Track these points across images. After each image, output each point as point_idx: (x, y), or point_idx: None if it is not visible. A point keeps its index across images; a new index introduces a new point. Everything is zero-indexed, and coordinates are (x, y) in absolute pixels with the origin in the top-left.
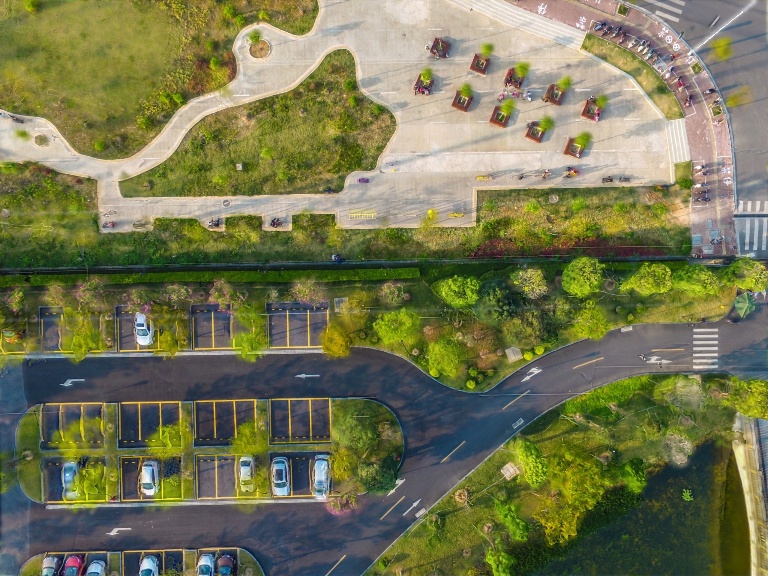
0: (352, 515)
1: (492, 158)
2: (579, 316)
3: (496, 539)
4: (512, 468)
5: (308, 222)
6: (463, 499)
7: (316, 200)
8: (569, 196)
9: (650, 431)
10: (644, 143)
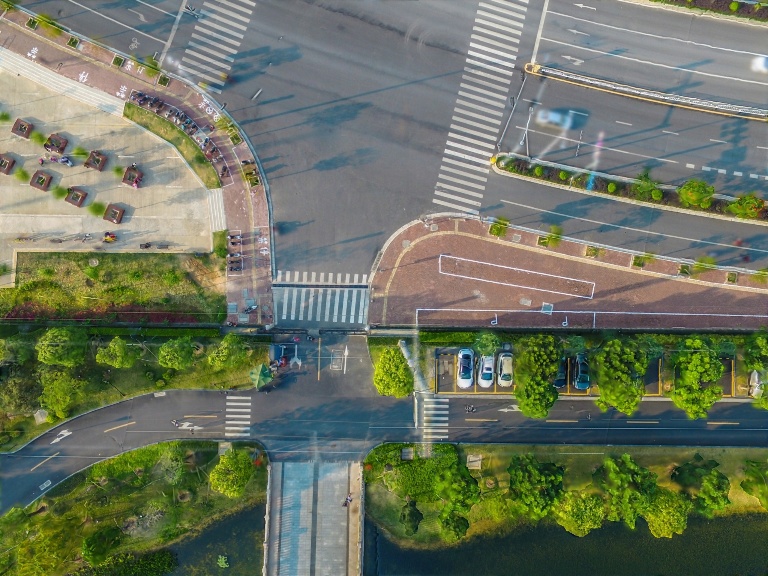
0: None
1: (33, 221)
2: (45, 387)
3: None
4: None
5: None
6: None
7: None
8: (109, 260)
9: None
10: (185, 211)
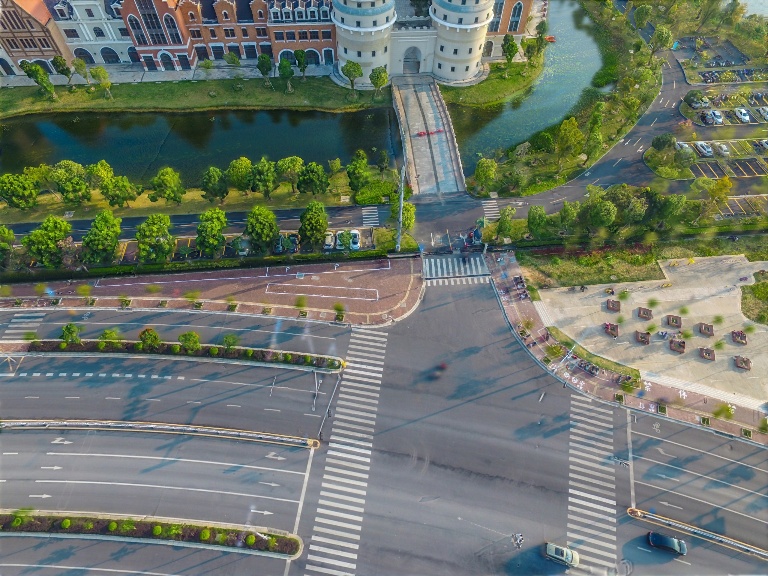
0: None
1: (666, 298)
2: None
3: None
4: (583, 158)
5: (763, 256)
6: (604, 145)
7: (766, 268)
8: (604, 280)
9: None
10: (566, 313)
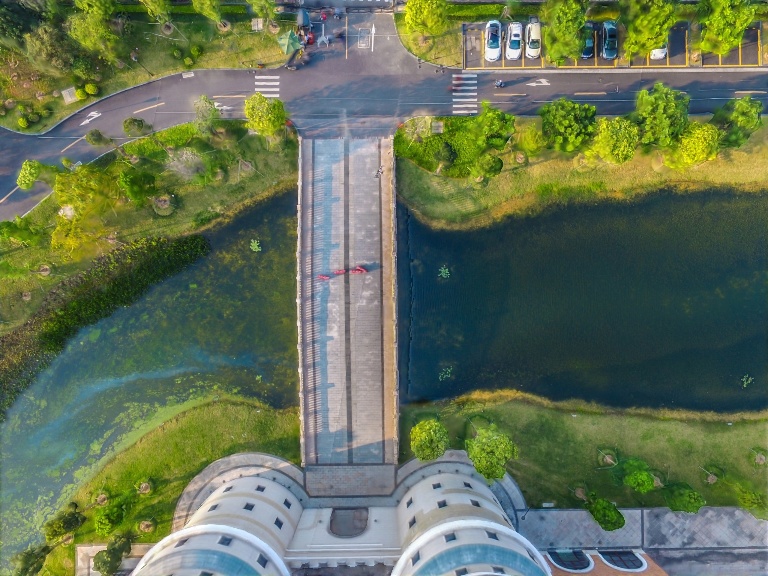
0: None
1: None
2: (76, 24)
3: (58, 284)
4: None
5: None
6: (16, 239)
7: None
8: None
9: (123, 124)
10: None
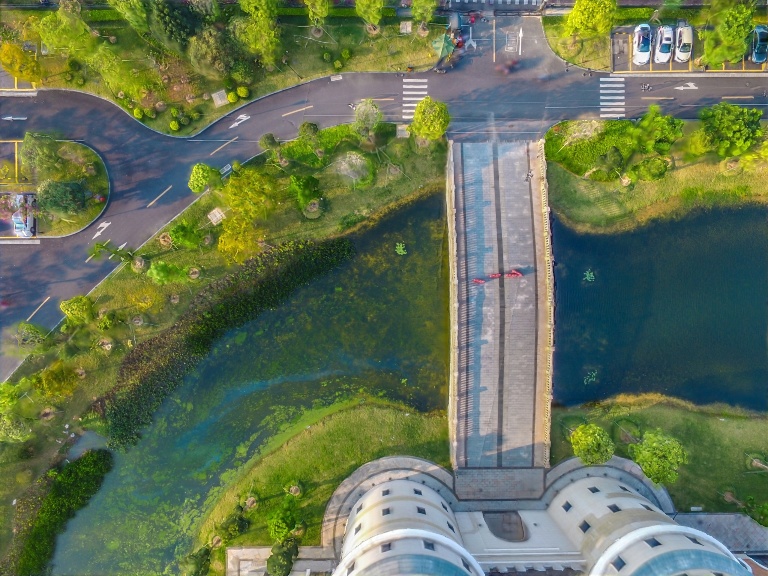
0: (57, 257)
1: None
2: None
3: (205, 287)
4: (219, 214)
5: None
6: (167, 242)
7: None
8: None
9: None
10: None
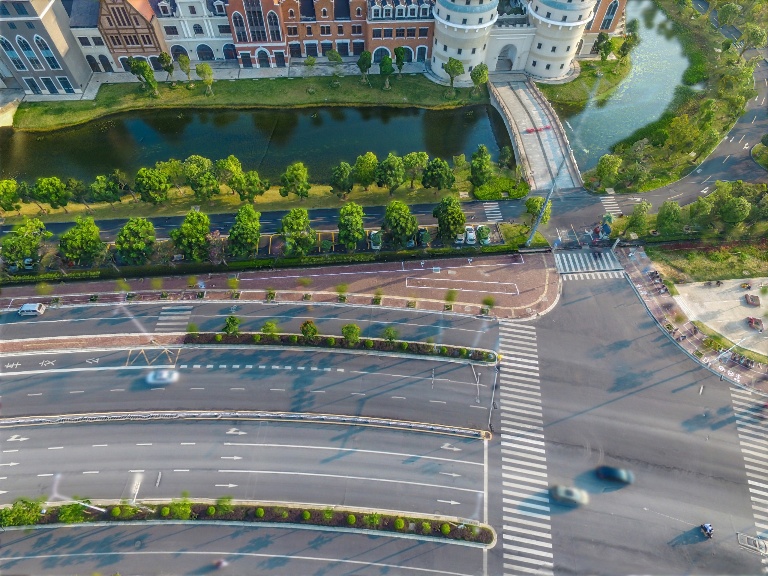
0: (760, 136)
1: None
2: None
3: None
4: (691, 155)
5: None
6: None
7: None
8: (737, 275)
9: None
10: (706, 307)
